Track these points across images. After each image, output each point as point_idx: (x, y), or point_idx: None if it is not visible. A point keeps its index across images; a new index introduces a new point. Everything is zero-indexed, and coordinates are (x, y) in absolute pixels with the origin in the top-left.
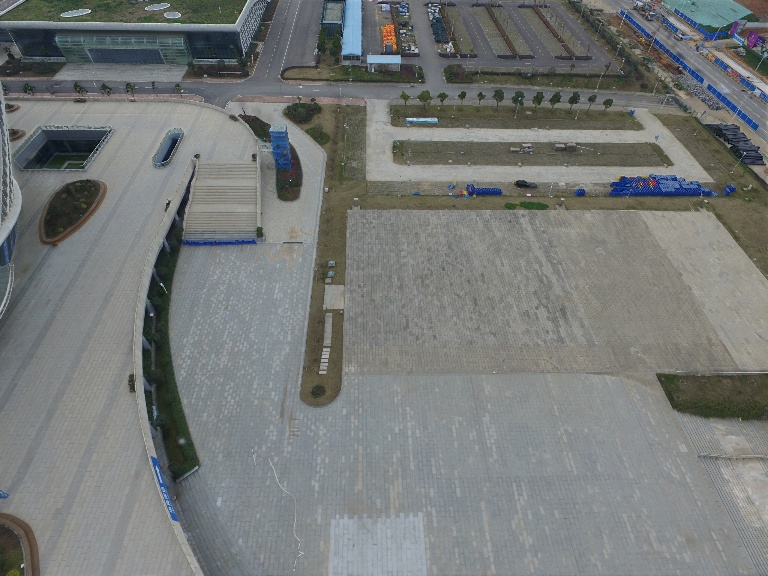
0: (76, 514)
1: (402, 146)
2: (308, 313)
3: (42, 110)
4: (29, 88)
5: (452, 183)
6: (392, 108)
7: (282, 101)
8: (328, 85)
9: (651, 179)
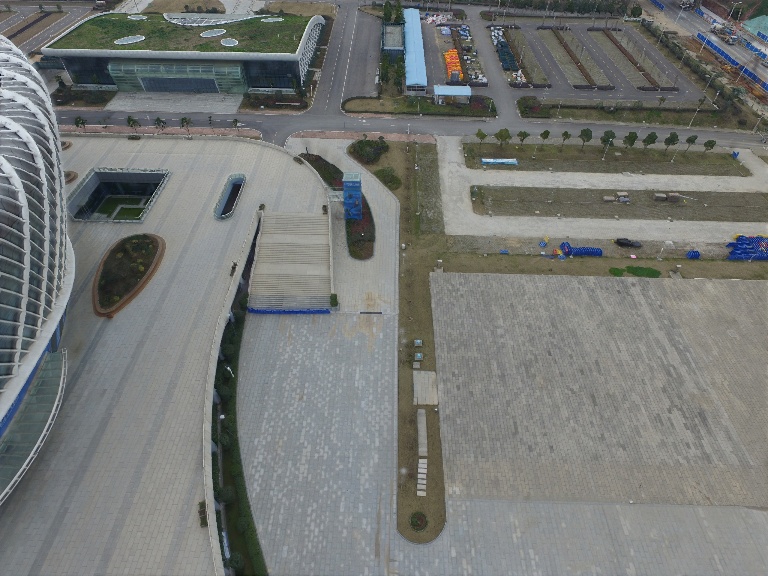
0: None
1: (481, 192)
2: (396, 408)
3: (95, 148)
4: (81, 122)
5: (543, 240)
6: (465, 146)
7: (345, 137)
8: (393, 119)
9: None
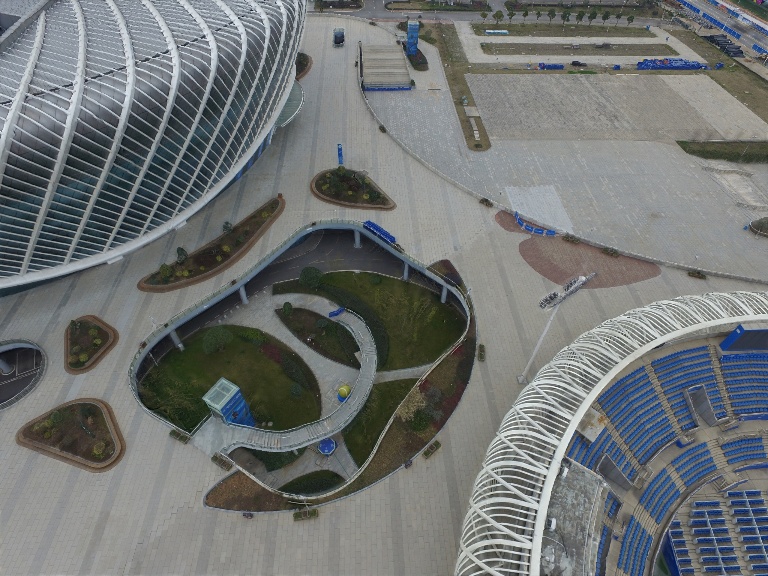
0: (382, 169)
1: (487, 45)
2: (458, 118)
3: None
4: None
5: (528, 64)
6: (473, 25)
7: (393, 21)
8: (422, 13)
9: (665, 60)
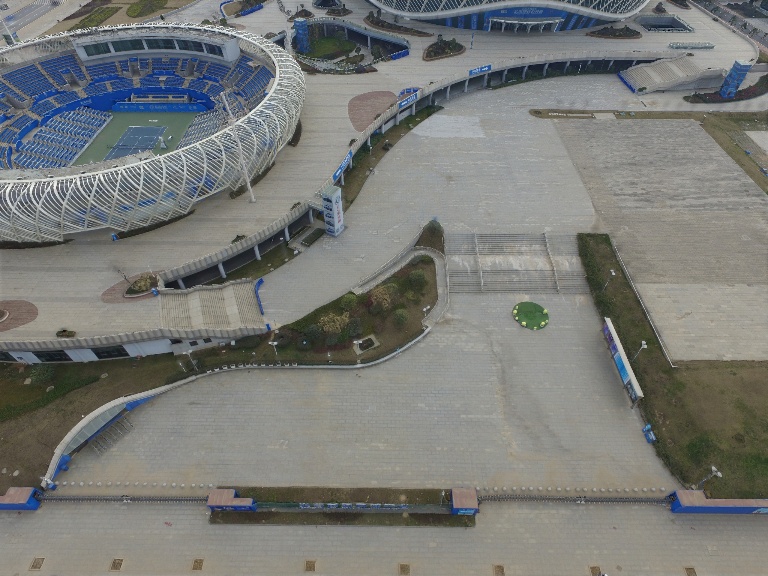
0: (468, 59)
1: None
2: None
3: (694, 14)
4: (716, 9)
5: None
6: None
7: None
8: None
9: None
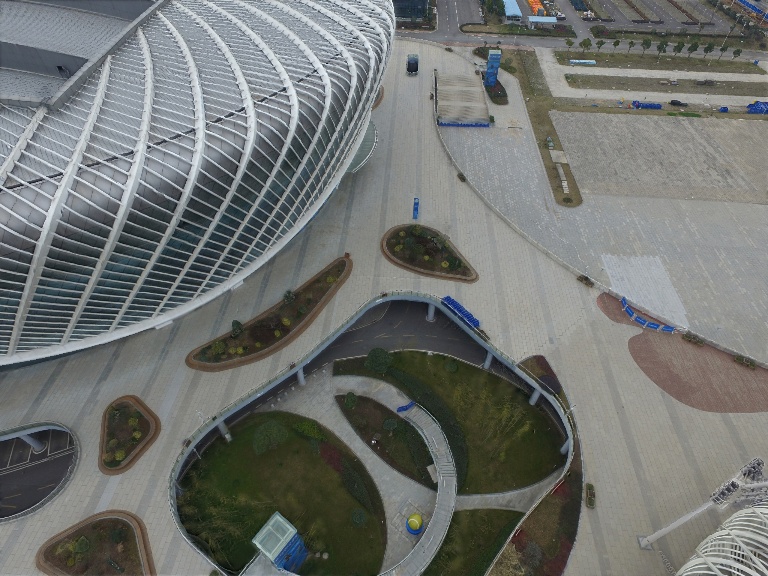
0: (461, 227)
1: (573, 77)
2: (543, 164)
3: None
4: None
5: (620, 101)
6: (556, 53)
7: (469, 46)
8: (500, 37)
9: None
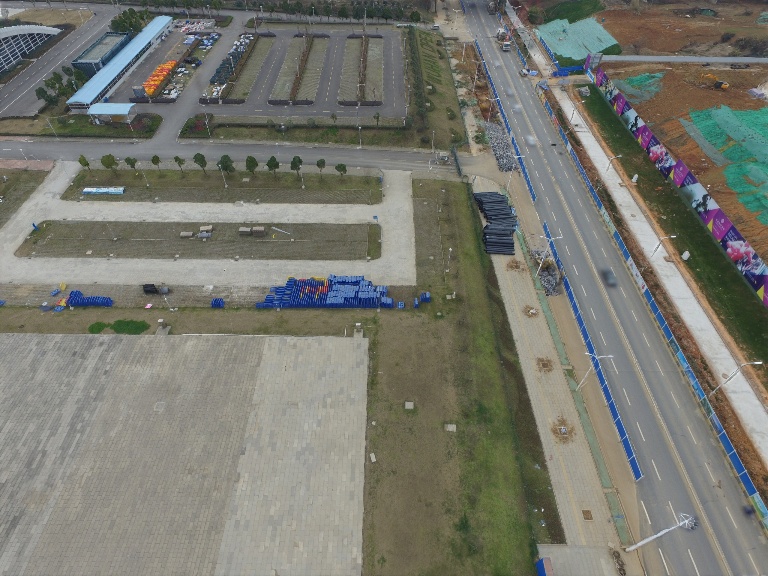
0: None
1: (45, 229)
2: None
3: None
4: None
5: None
6: (80, 174)
7: None
8: (29, 142)
9: (325, 283)
